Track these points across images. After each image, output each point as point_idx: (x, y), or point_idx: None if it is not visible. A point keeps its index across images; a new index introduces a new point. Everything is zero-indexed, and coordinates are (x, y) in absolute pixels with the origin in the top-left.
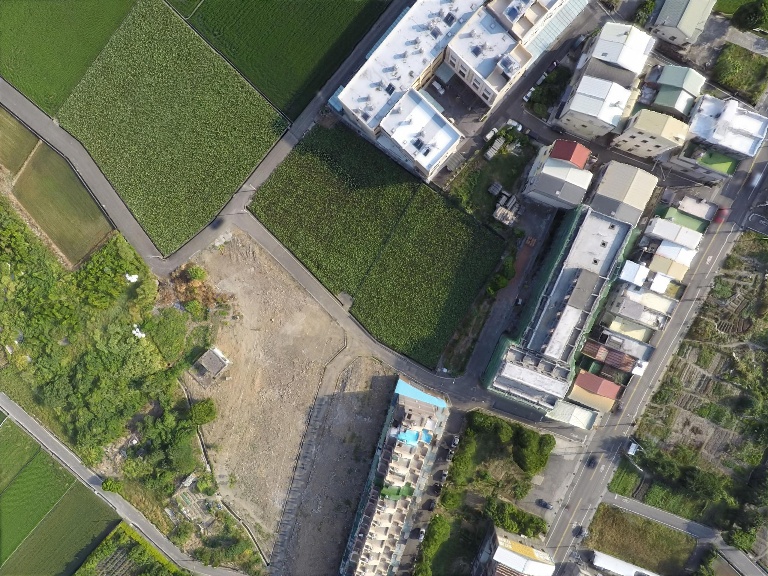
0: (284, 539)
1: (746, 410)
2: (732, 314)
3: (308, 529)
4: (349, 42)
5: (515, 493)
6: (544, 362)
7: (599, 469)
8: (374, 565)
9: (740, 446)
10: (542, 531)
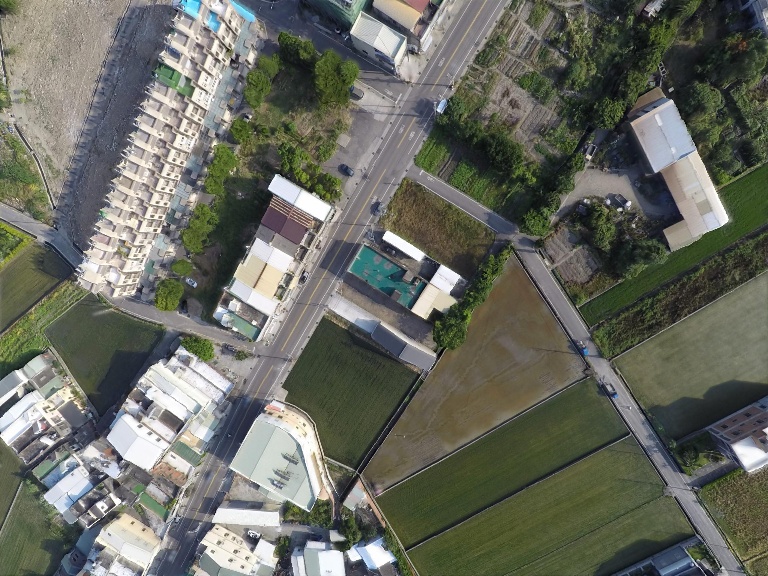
0: (74, 178)
1: (567, 80)
2: None
3: (99, 168)
4: None
5: (319, 154)
6: None
7: (408, 136)
8: (137, 165)
9: (556, 127)
10: (335, 190)
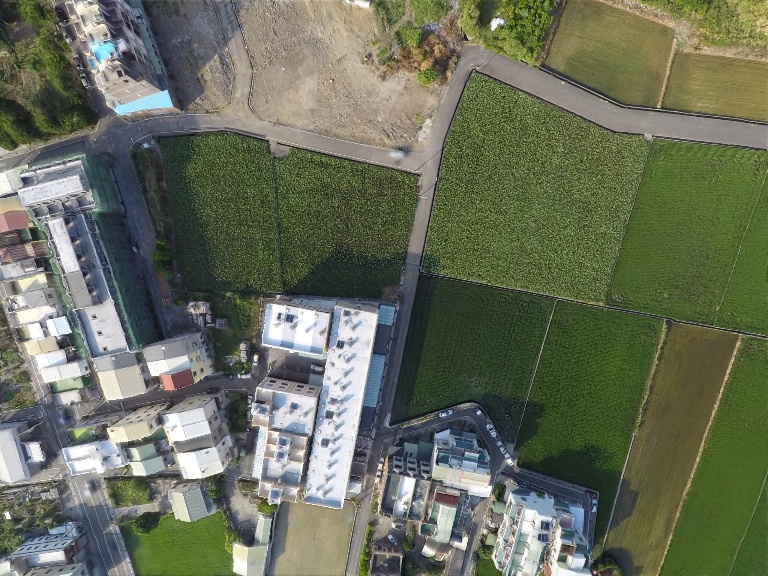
0: None
1: None
2: None
3: None
4: (410, 360)
5: None
6: (62, 211)
7: None
8: None
9: None
10: None
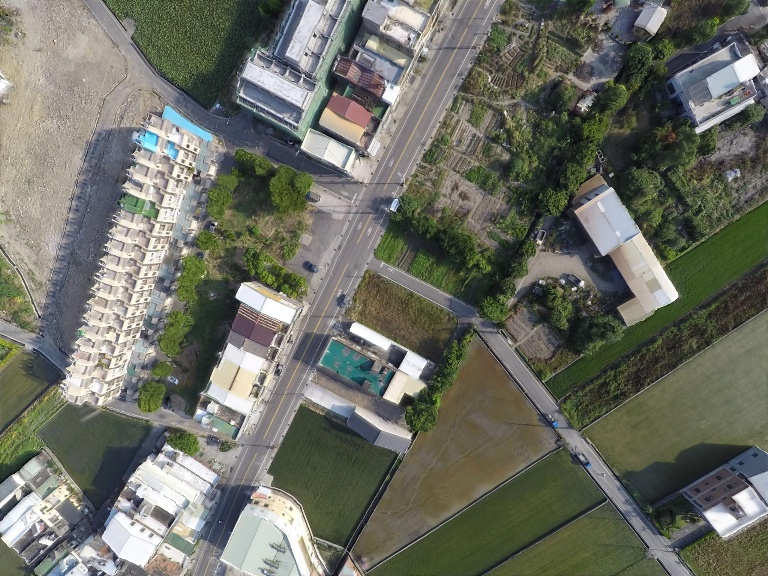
0: (56, 289)
1: (511, 173)
2: (506, 67)
3: (79, 278)
4: None
5: (283, 253)
6: (292, 74)
7: (366, 232)
8: (110, 286)
9: (505, 216)
10: (300, 289)
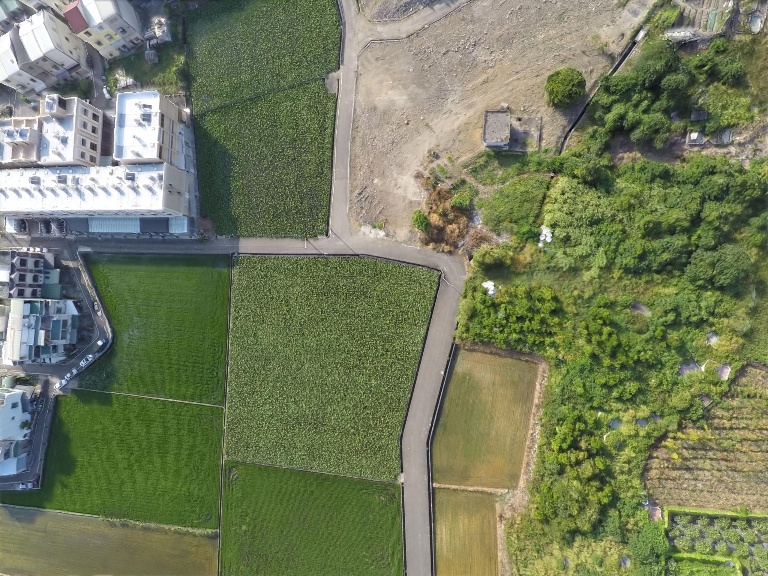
0: None
1: None
2: None
3: None
4: (147, 262)
5: None
6: None
7: None
8: None
9: None
10: None
